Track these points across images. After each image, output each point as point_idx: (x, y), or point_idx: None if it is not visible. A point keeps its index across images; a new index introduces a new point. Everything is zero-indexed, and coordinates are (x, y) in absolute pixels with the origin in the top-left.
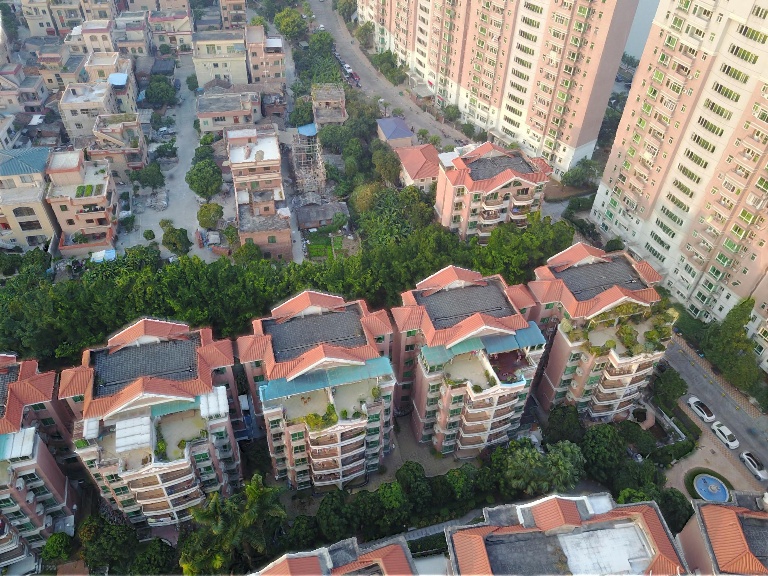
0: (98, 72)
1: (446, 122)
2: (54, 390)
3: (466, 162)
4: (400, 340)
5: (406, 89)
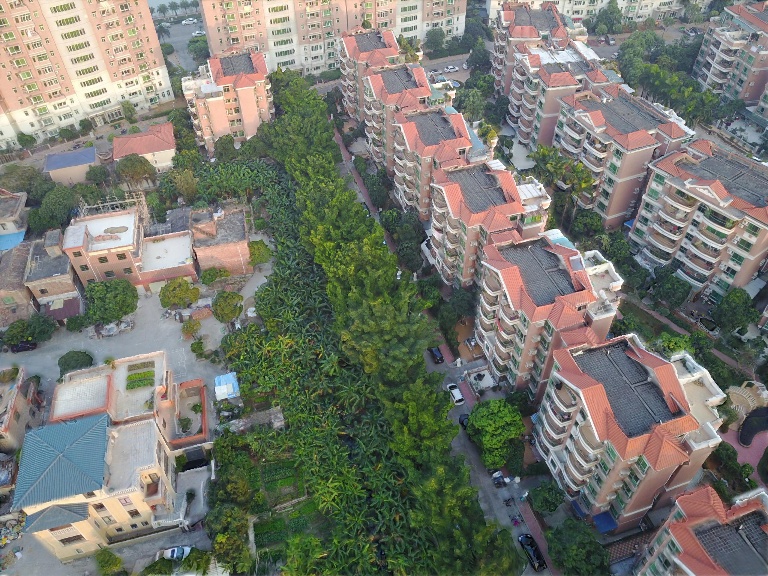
0: None
1: (33, 152)
2: None
3: None
4: None
5: None
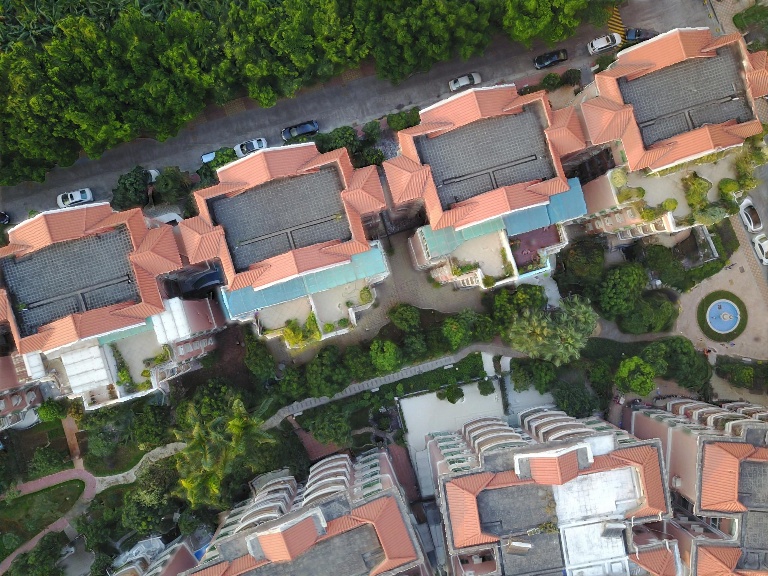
0: None
1: None
2: None
3: None
4: None
5: None
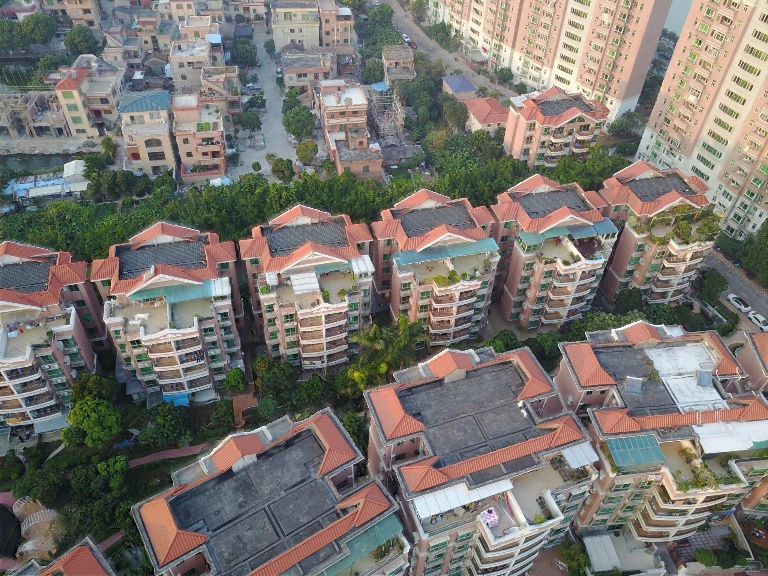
0: (194, 33)
1: (500, 83)
2: (237, 253)
3: (535, 103)
4: (498, 231)
5: (460, 55)
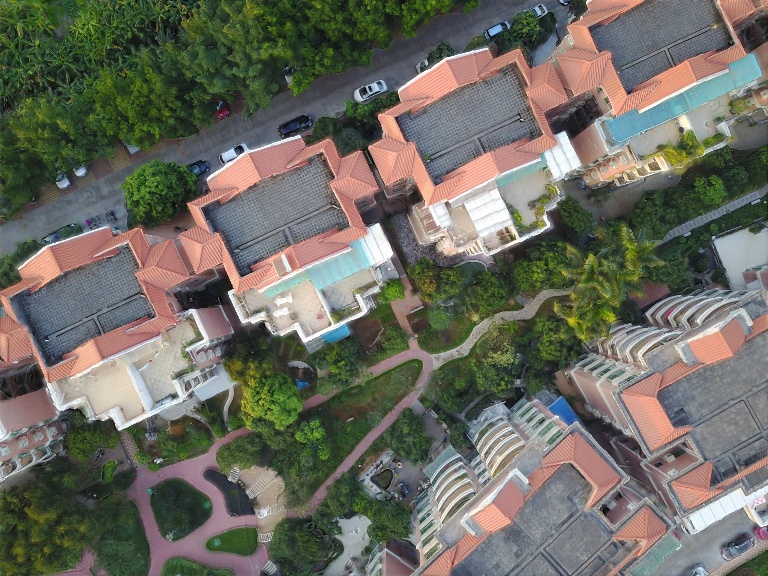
0: None
1: None
2: (374, 175)
3: None
4: None
5: None
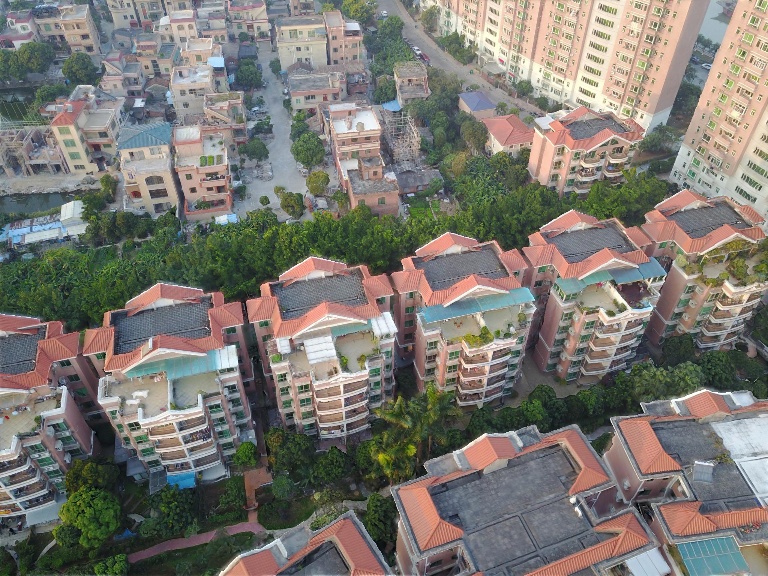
0: (196, 57)
1: (519, 97)
2: (244, 316)
3: (562, 125)
4: (531, 276)
5: (476, 68)
